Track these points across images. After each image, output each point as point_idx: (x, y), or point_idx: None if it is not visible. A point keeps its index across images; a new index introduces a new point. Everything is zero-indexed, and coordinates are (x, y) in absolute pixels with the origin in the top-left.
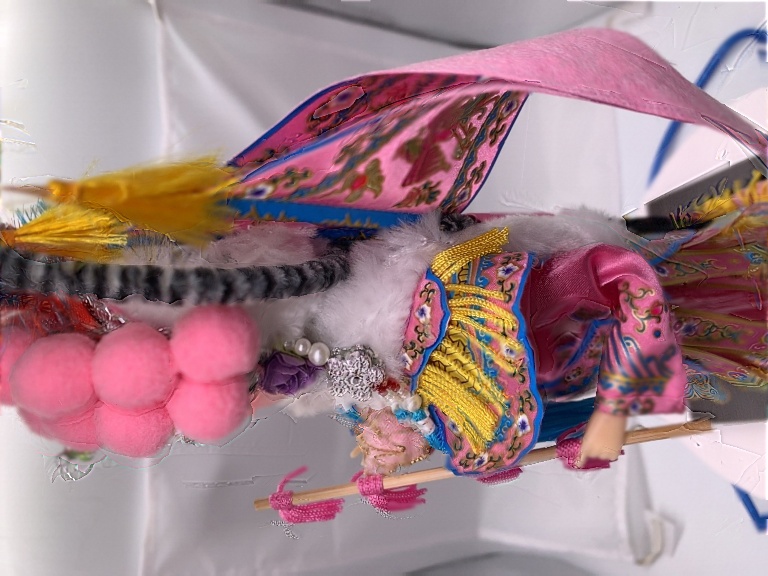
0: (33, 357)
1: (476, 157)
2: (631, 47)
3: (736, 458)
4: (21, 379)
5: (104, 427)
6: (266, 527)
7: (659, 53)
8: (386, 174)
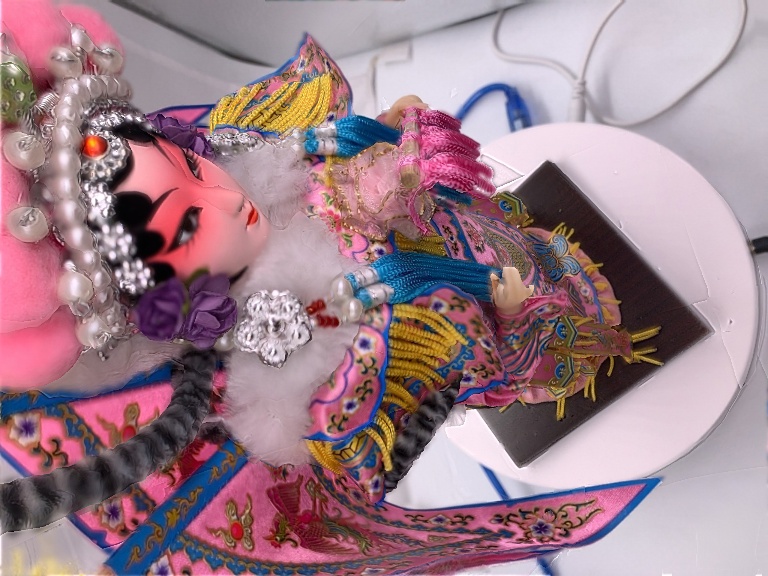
0: None
1: None
2: None
3: (718, 283)
4: None
5: None
6: None
7: None
8: None
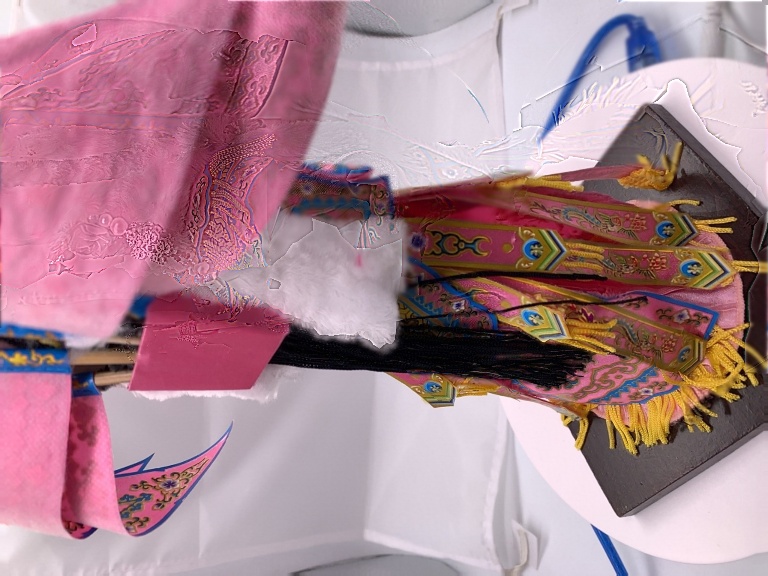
0: None
1: (252, 73)
2: None
3: None
4: None
5: None
6: (111, 353)
7: None
8: (147, 90)
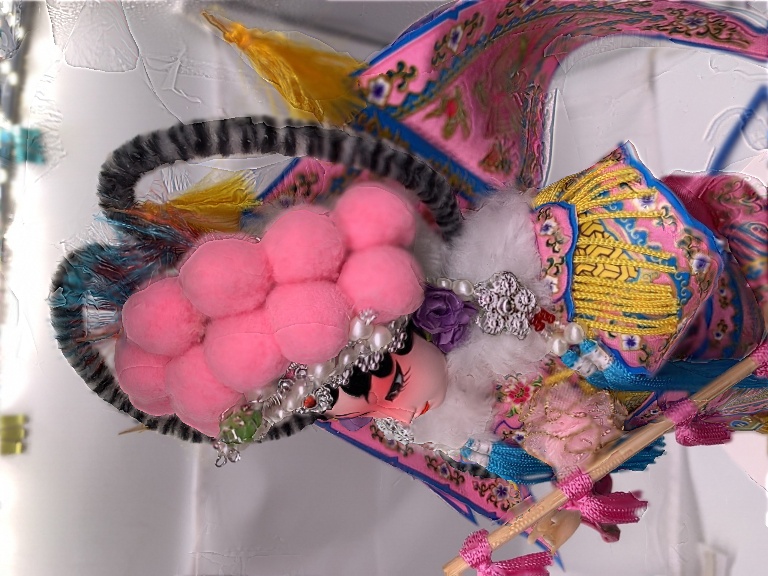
0: (203, 244)
1: (536, 134)
2: None
3: None
4: None
5: (280, 303)
6: (460, 568)
7: None
8: None
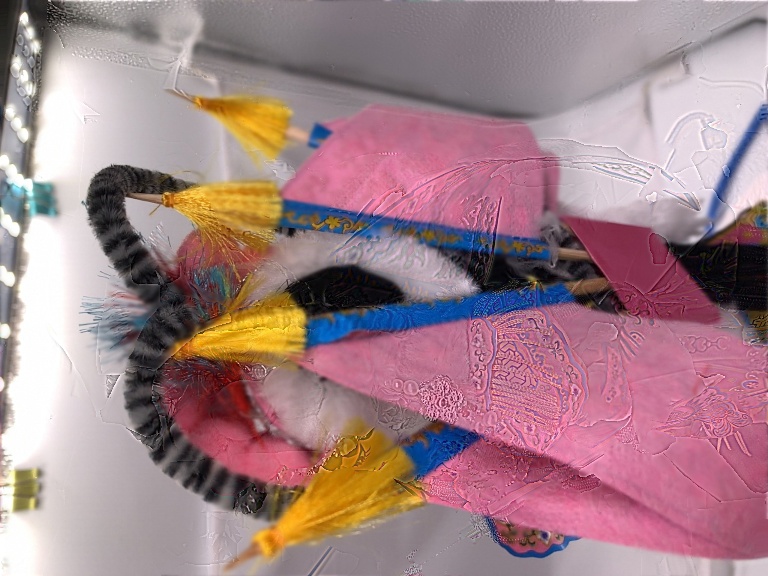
0: (227, 390)
1: (480, 241)
2: (575, 210)
3: None
4: (222, 404)
5: (279, 434)
6: None
7: (599, 213)
8: None
